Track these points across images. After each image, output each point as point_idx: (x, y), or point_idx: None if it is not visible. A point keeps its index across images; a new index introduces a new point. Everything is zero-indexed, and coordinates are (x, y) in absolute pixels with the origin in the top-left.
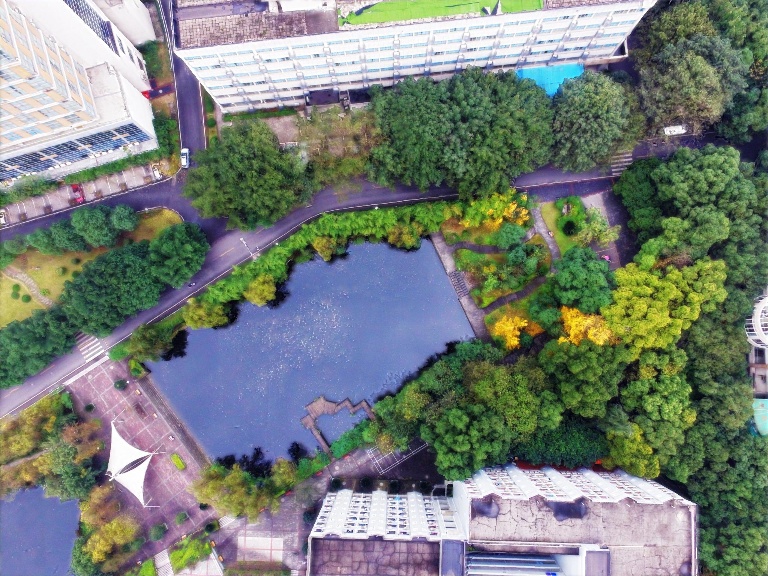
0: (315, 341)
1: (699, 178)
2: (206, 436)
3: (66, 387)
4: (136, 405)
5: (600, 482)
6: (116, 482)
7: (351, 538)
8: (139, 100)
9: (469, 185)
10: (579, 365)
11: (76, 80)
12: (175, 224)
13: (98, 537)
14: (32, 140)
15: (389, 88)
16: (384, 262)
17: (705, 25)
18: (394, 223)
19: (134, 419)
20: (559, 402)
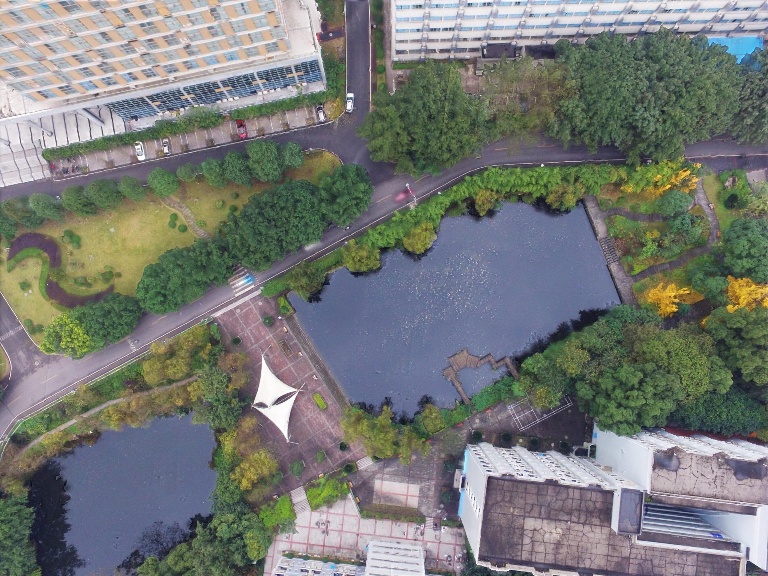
0: (462, 295)
1: None
2: (347, 379)
3: (214, 319)
4: (283, 342)
5: (766, 450)
6: (257, 416)
7: (528, 480)
8: None
9: (646, 147)
10: (763, 330)
11: (281, 8)
12: (338, 166)
13: (248, 465)
14: (224, 66)
15: None
16: (535, 222)
17: None
18: (558, 182)
19: (279, 356)
20: (726, 368)
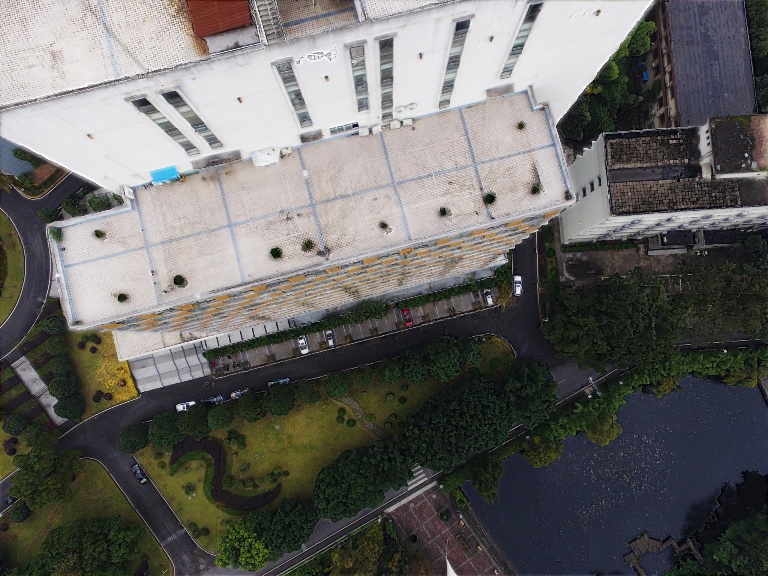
0: (638, 476)
1: None
2: (527, 569)
3: (388, 515)
4: (461, 537)
5: None
6: None
7: None
8: None
9: None
10: None
11: None
12: None
13: None
14: None
15: (738, 228)
16: (708, 397)
17: None
18: (742, 367)
19: (457, 550)
20: None
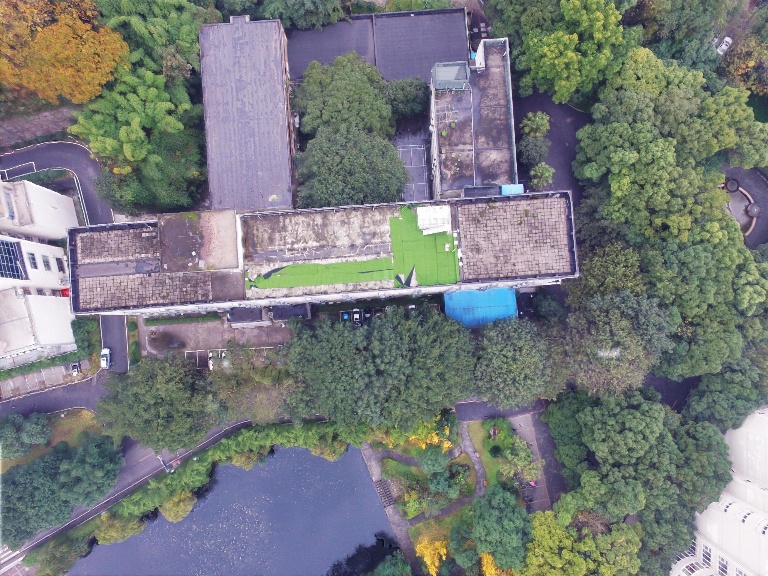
0: (236, 547)
1: (618, 443)
2: None
3: None
4: None
5: None
6: None
7: None
8: (55, 309)
9: None
10: None
11: None
12: None
13: None
14: None
15: None
16: (309, 467)
17: (634, 280)
18: (315, 443)
19: None
20: None
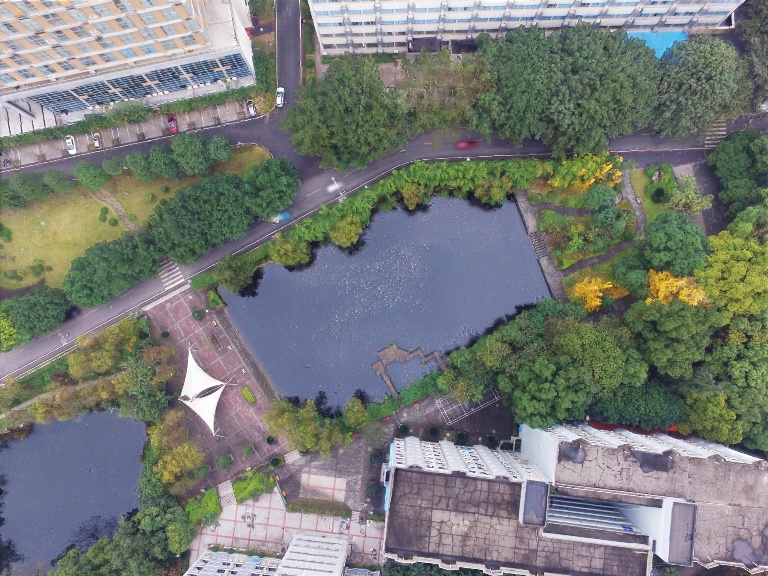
0: (392, 289)
1: None
2: (277, 373)
3: (144, 312)
4: (212, 335)
5: (681, 443)
6: (186, 409)
7: (435, 471)
8: (243, 34)
9: (567, 141)
10: (673, 322)
11: (197, 1)
12: None
13: (170, 458)
14: (144, 60)
15: None
16: (466, 217)
17: None
18: (484, 176)
19: (208, 349)
20: (643, 361)
